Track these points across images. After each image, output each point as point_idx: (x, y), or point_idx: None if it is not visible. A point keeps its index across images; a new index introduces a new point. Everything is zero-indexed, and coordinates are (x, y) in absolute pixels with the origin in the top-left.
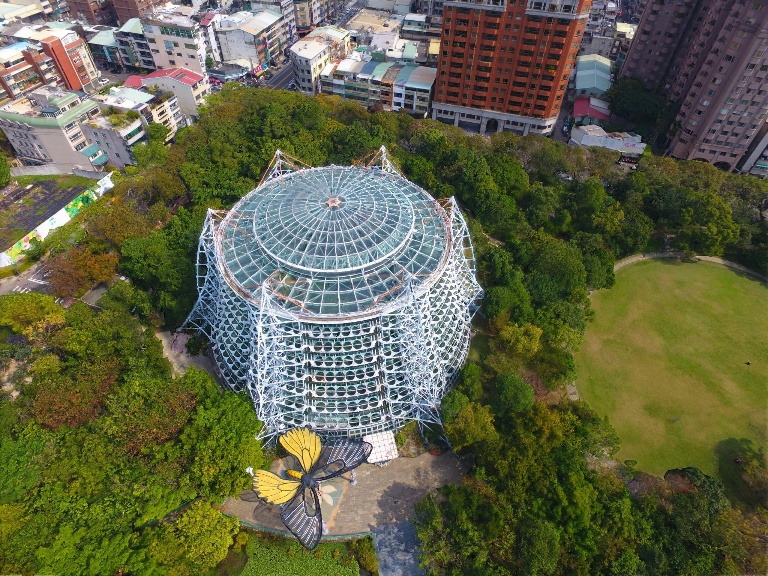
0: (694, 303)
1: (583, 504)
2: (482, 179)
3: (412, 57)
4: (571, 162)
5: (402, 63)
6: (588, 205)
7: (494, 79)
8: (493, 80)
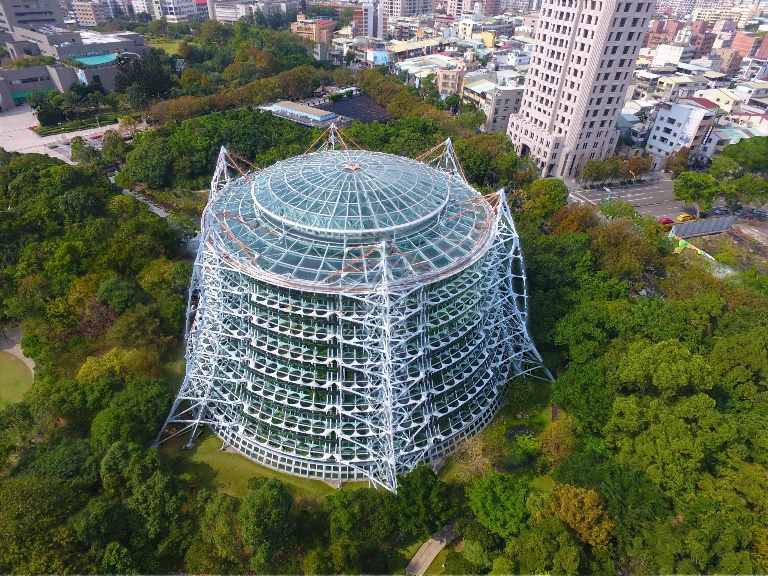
0: None
1: None
2: None
3: None
4: None
5: None
6: None
7: None
8: None
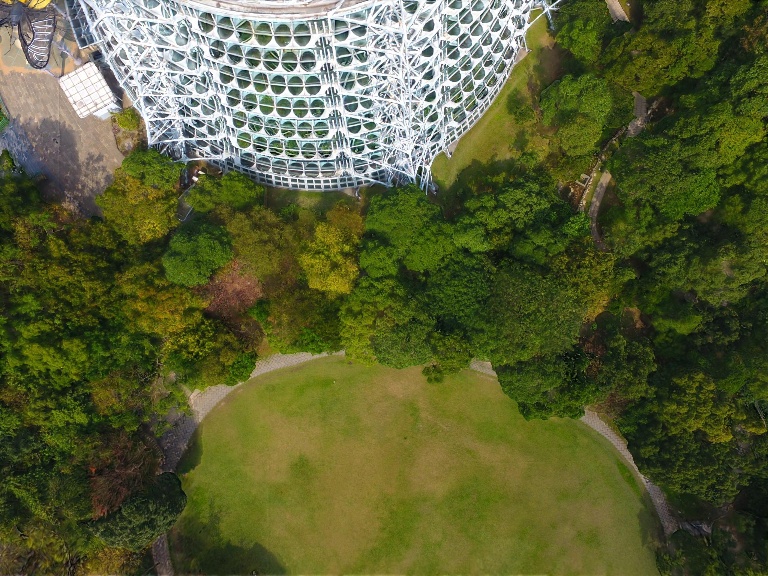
0: (548, 556)
1: (33, 358)
2: (744, 114)
3: None
4: None
5: None
6: (733, 365)
7: None
8: None
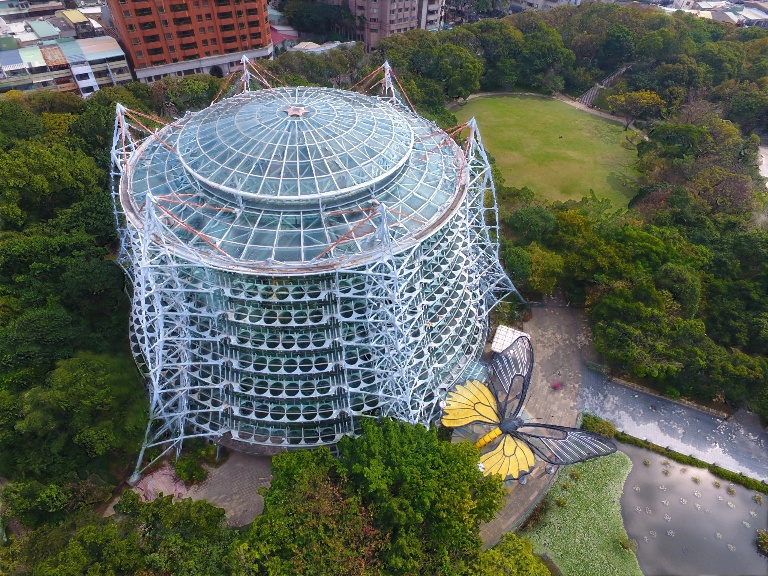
0: (499, 124)
1: None
2: None
3: (54, 33)
4: (337, 64)
5: (48, 42)
6: None
7: (195, 17)
8: (194, 19)
